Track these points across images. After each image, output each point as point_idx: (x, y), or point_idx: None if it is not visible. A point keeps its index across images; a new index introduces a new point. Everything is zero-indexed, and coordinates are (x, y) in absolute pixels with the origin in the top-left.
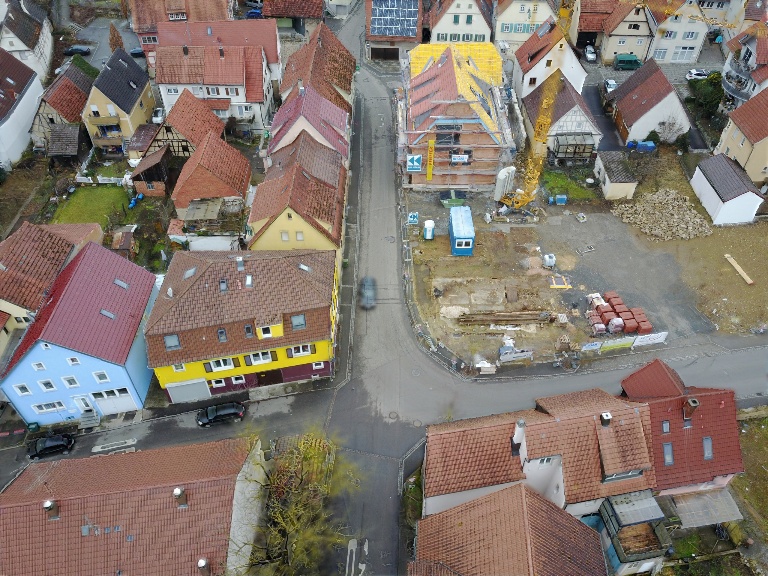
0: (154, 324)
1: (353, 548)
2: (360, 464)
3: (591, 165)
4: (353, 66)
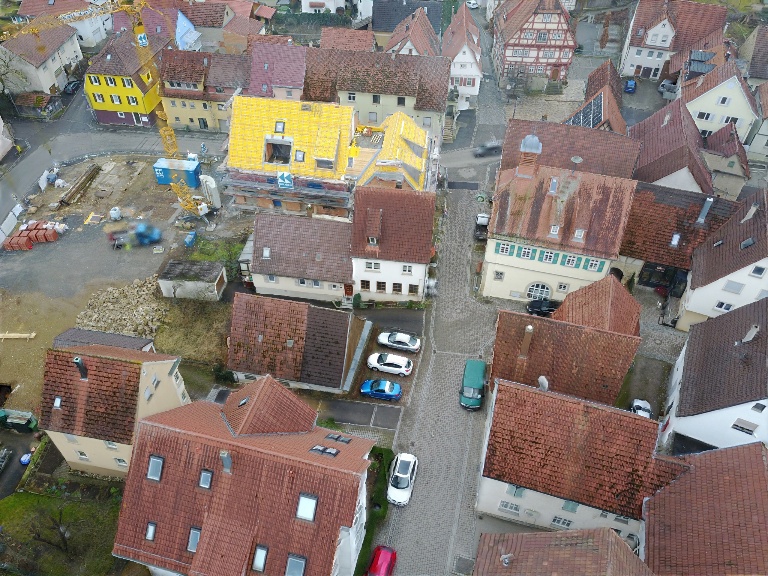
0: (114, 33)
1: None
2: (36, 128)
3: (238, 281)
4: (422, 106)
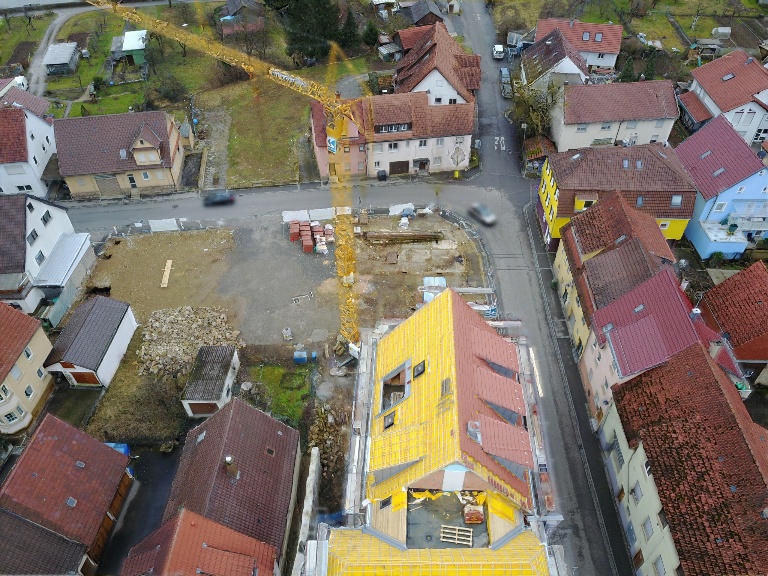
0: None
1: (502, 147)
2: (506, 171)
3: None
4: None
